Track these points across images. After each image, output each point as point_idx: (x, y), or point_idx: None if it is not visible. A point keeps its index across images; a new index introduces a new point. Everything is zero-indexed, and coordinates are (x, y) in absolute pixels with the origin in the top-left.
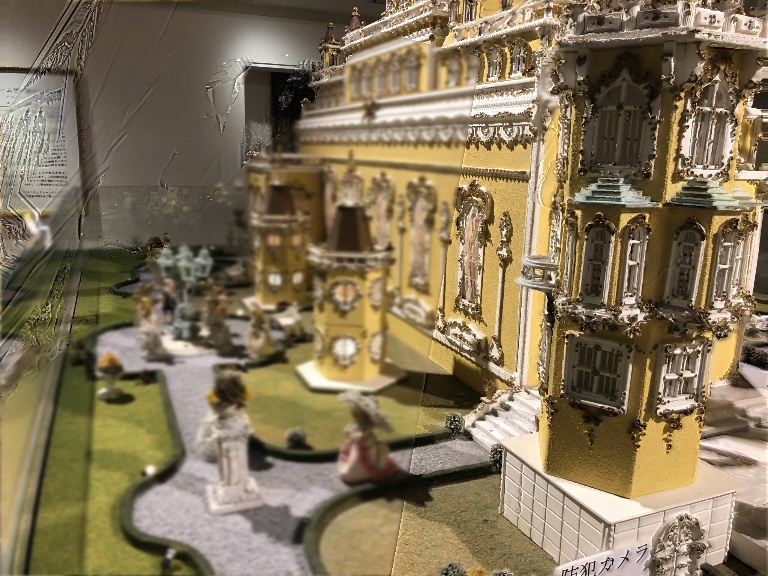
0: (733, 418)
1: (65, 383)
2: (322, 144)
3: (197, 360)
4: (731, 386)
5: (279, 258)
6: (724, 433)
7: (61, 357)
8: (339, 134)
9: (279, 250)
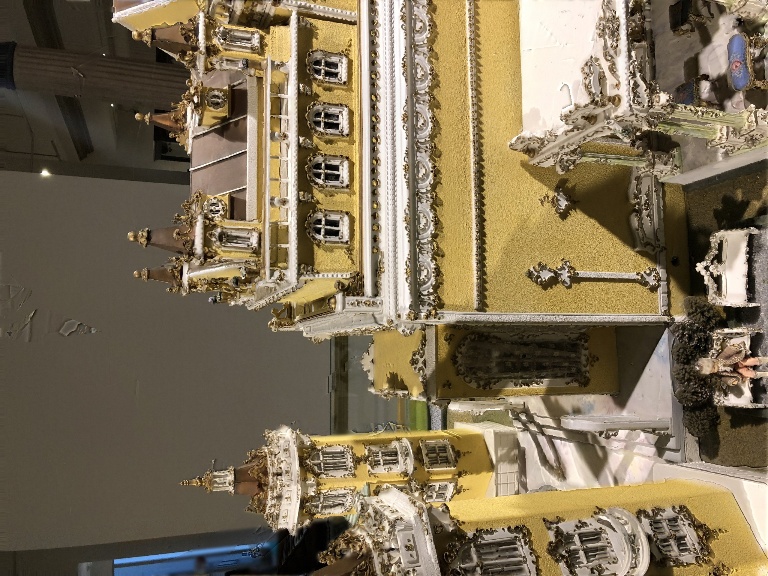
0: (584, 435)
1: (307, 546)
2: (287, 572)
3: (302, 571)
4: (609, 397)
5: (296, 573)
6: (574, 442)
7: (308, 530)
8: (286, 573)
9: (295, 572)
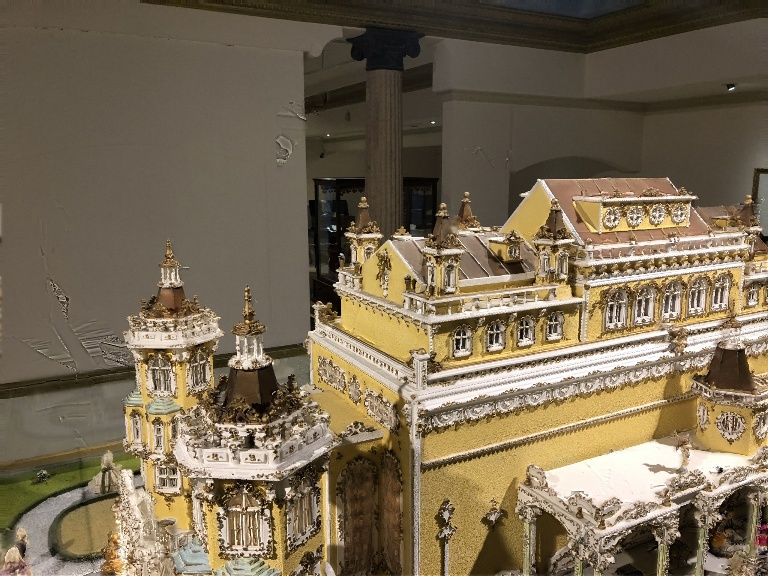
0: None
1: None
2: None
3: None
4: None
5: None
6: None
7: None
8: None
9: None
